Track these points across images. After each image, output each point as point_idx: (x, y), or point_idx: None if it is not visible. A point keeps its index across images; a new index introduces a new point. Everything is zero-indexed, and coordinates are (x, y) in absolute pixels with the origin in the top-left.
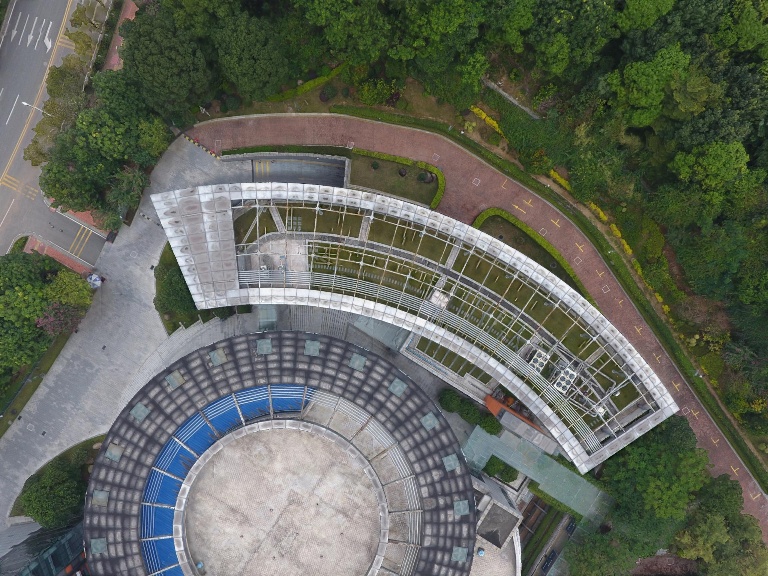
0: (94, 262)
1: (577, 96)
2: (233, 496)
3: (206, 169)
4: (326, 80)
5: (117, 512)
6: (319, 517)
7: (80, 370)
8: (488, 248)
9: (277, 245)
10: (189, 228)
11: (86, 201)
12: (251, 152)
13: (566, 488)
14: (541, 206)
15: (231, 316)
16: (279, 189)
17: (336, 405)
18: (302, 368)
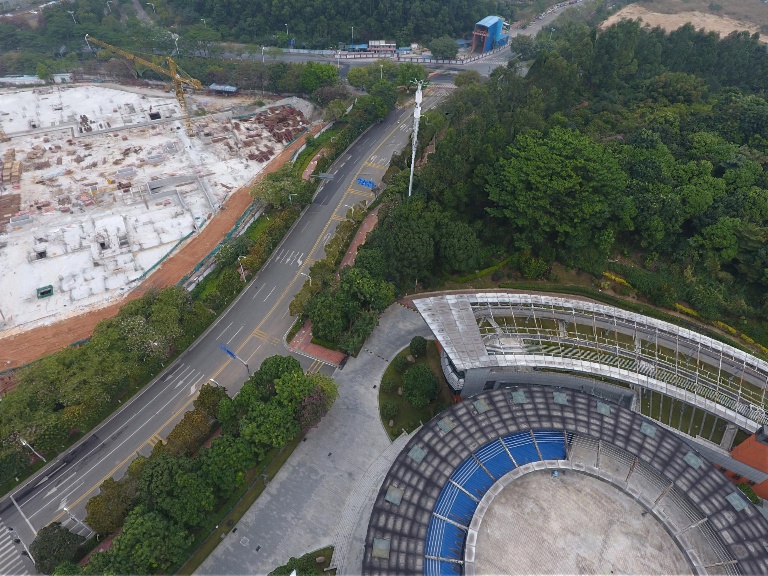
0: None
1: (676, 254)
2: (515, 563)
3: (414, 321)
4: (496, 268)
5: (399, 567)
6: None
7: (305, 477)
8: (668, 329)
9: None
10: (443, 318)
11: (340, 327)
12: None
13: None
14: None
15: None
16: (502, 297)
17: (598, 447)
18: (556, 415)
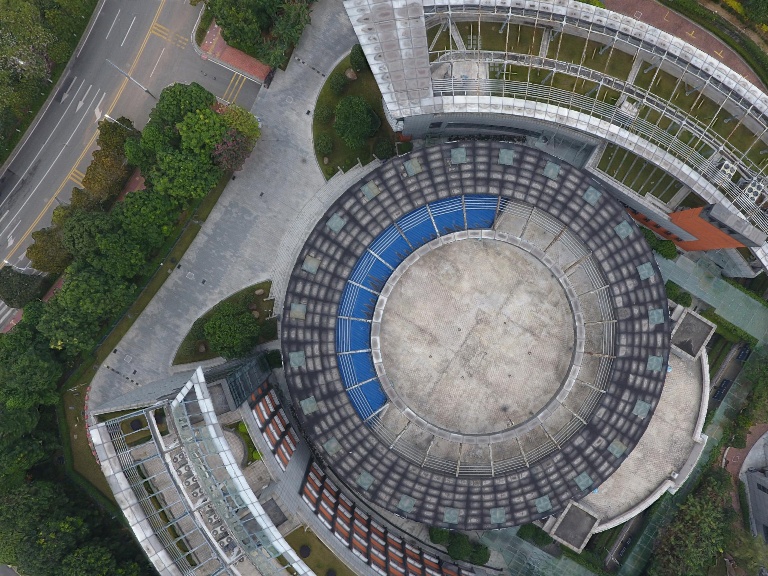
0: (250, 108)
1: None
2: (421, 316)
3: None
4: None
5: (314, 325)
6: (507, 336)
7: (238, 217)
8: (680, 53)
9: (457, 65)
10: (382, 35)
11: (255, 32)
12: None
13: (741, 312)
14: (704, 37)
15: (391, 158)
16: None
17: (530, 215)
18: (496, 178)
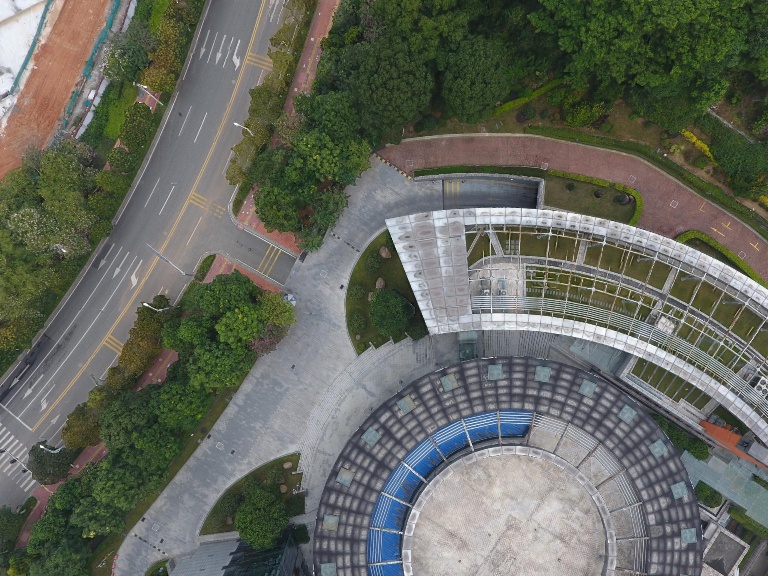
0: (284, 281)
1: None
2: (452, 521)
3: (397, 189)
4: (526, 101)
5: (346, 537)
6: (537, 542)
7: (269, 389)
8: (720, 275)
9: None
10: (423, 253)
11: None
12: (445, 172)
13: None
14: (740, 229)
15: (423, 337)
16: (513, 214)
17: (564, 431)
18: (532, 394)
